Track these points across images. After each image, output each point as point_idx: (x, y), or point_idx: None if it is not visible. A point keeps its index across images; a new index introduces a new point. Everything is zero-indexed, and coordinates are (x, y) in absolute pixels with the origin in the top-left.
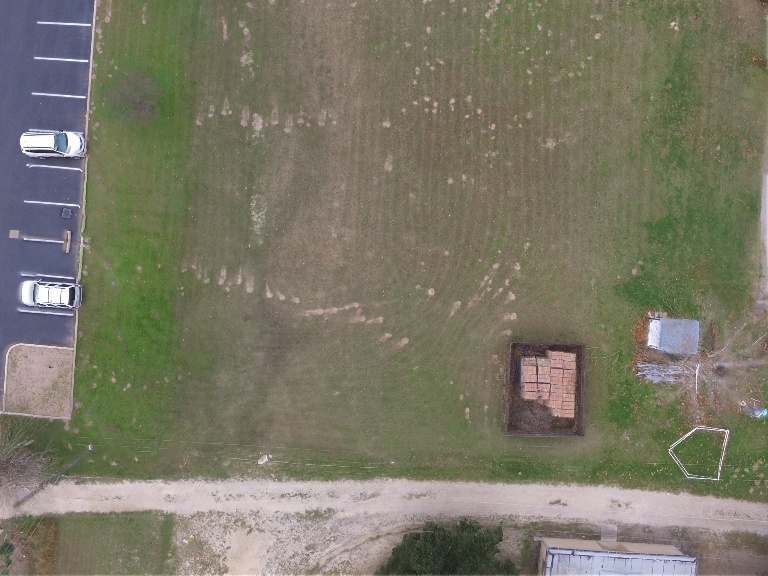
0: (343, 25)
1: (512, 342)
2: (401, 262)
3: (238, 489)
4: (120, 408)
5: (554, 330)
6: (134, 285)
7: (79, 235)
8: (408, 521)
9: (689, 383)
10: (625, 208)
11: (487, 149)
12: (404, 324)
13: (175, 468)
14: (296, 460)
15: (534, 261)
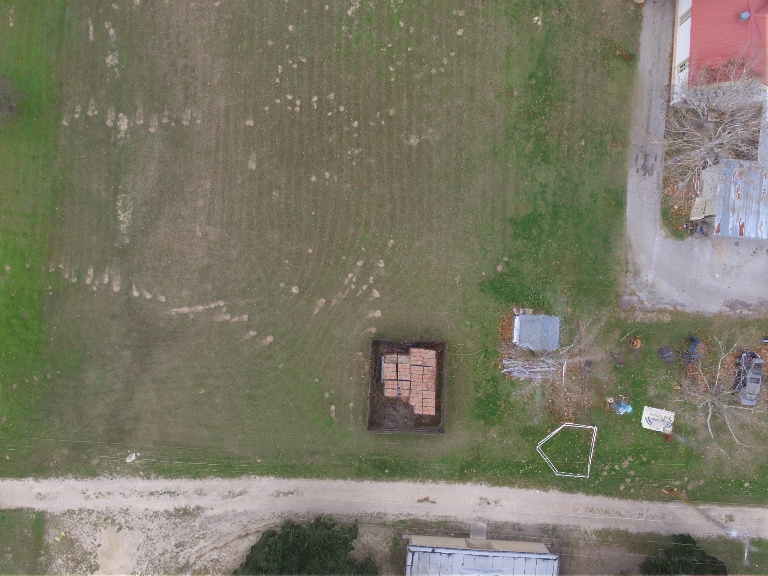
0: (206, 24)
1: None
2: (265, 260)
3: (107, 487)
4: None
5: (419, 327)
6: (2, 285)
7: None
8: (276, 519)
9: (556, 380)
10: (489, 204)
11: (350, 146)
12: (269, 322)
13: (46, 466)
14: (163, 458)
15: (398, 258)
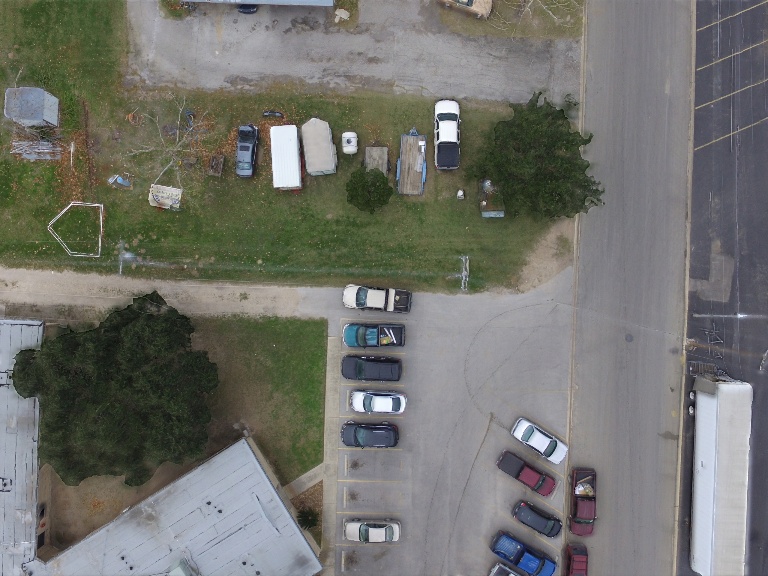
0: None
1: None
2: None
3: None
4: None
5: None
6: None
7: None
8: None
9: (64, 160)
10: None
11: None
12: None
13: None
14: None
15: None
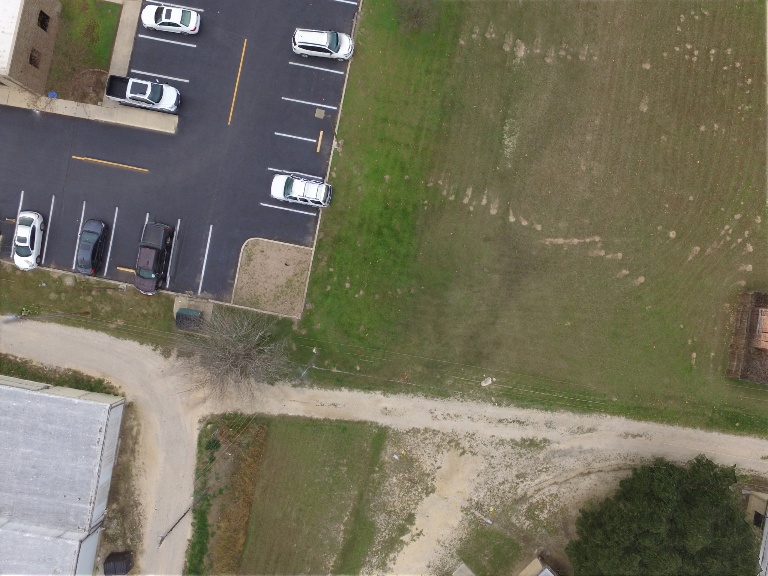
0: None
1: (753, 291)
2: (645, 202)
3: (457, 409)
4: (350, 314)
5: None
6: (379, 193)
7: (333, 136)
8: (621, 460)
9: None
10: None
11: (741, 102)
12: (642, 263)
13: None
14: (520, 386)
15: None
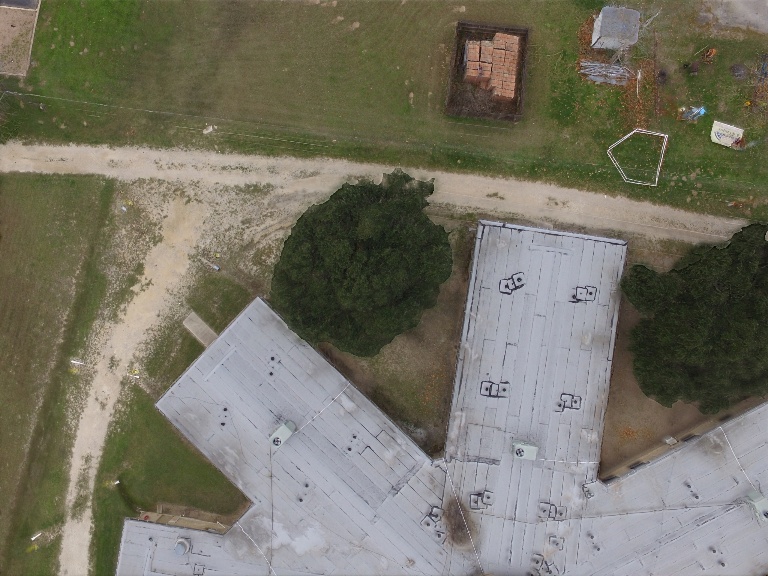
0: None
1: (458, 22)
2: None
3: (181, 158)
4: (75, 70)
5: (501, 25)
6: None
7: None
8: None
9: (630, 87)
10: None
11: None
12: (356, 9)
13: (122, 134)
14: (240, 131)
15: None
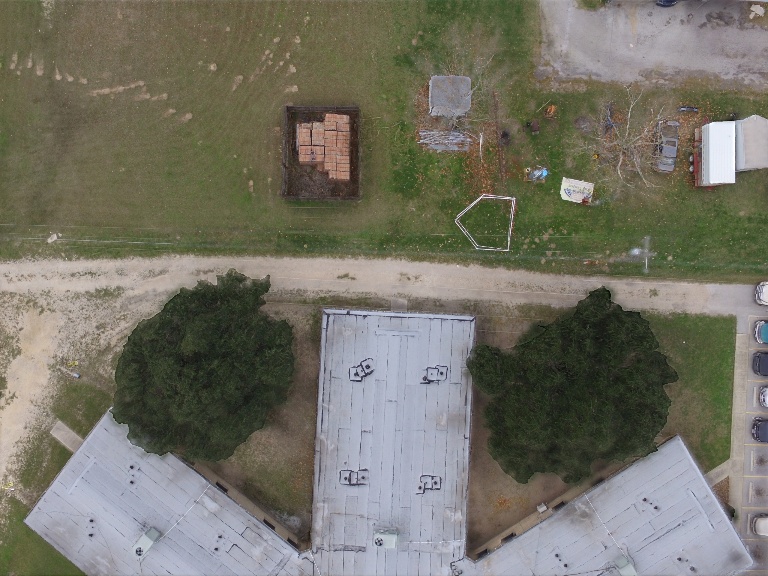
0: None
1: (286, 106)
2: (184, 40)
3: (30, 269)
4: None
5: (335, 101)
6: None
7: None
8: None
9: (473, 151)
10: None
11: None
12: (188, 100)
13: None
14: (84, 237)
15: (314, 34)
